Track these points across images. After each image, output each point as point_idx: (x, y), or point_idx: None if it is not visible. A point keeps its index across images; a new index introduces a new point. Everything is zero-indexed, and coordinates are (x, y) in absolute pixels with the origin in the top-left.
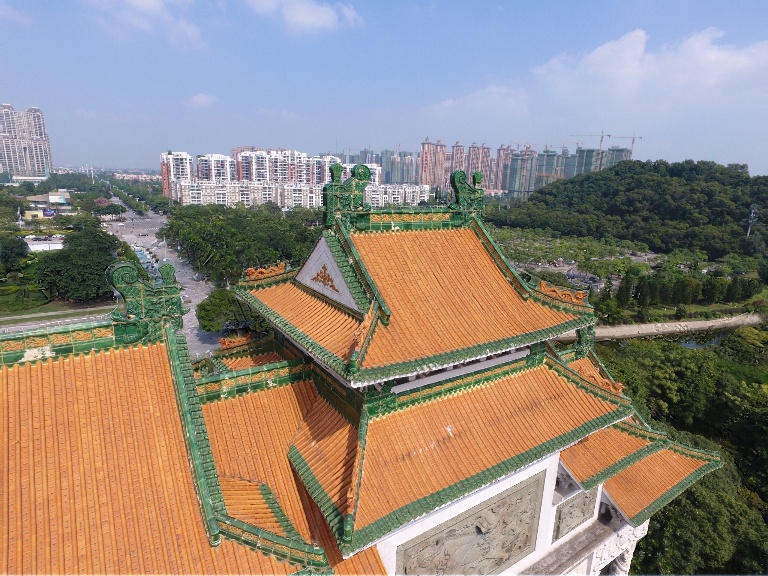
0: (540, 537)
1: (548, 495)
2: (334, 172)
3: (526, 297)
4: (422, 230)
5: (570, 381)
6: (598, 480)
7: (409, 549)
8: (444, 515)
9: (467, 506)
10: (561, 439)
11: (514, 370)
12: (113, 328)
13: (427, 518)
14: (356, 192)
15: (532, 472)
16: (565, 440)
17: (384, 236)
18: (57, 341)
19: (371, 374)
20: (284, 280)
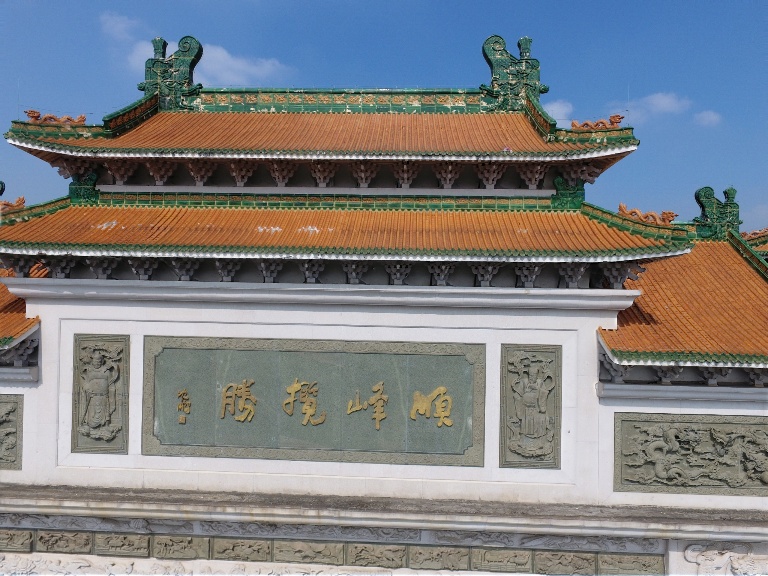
0: None
1: None
2: None
3: None
4: None
5: None
6: None
7: None
8: None
9: None
10: None
11: None
12: (695, 227)
13: None
14: None
15: None
16: None
17: None
18: None
19: None
20: None
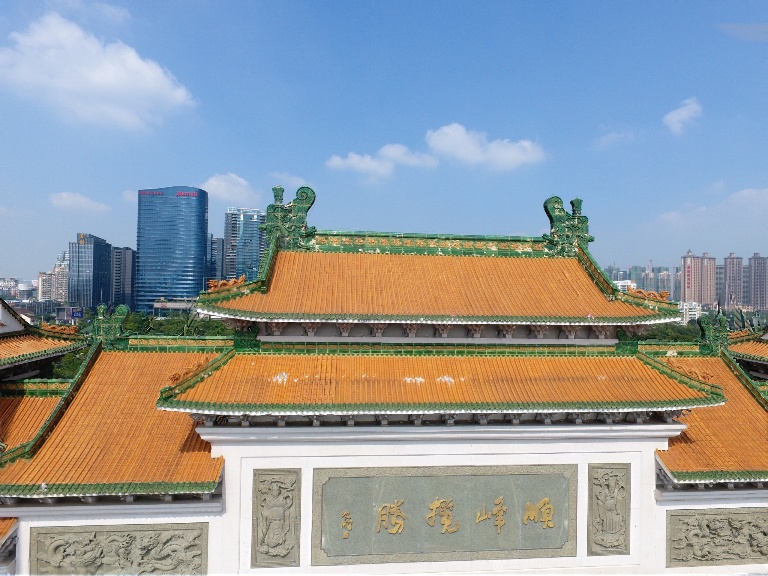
0: None
1: None
2: None
3: None
4: None
5: None
6: None
7: None
8: None
9: None
10: None
11: None
12: (698, 346)
13: None
14: None
15: None
16: None
17: None
18: (678, 349)
19: None
20: (748, 340)
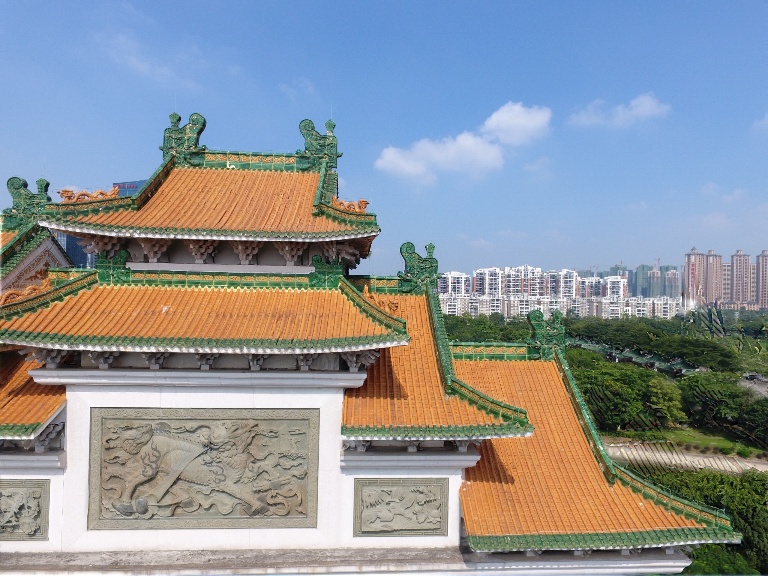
0: (324, 511)
1: (330, 450)
2: (171, 119)
3: (314, 212)
4: (261, 170)
5: (355, 305)
6: (369, 431)
7: (109, 420)
8: (152, 399)
9: (185, 403)
10: (280, 342)
11: (289, 284)
12: (3, 218)
13: (129, 392)
14: (190, 135)
15: (292, 403)
16: (285, 343)
17: (216, 171)
18: None
19: (62, 220)
20: None
